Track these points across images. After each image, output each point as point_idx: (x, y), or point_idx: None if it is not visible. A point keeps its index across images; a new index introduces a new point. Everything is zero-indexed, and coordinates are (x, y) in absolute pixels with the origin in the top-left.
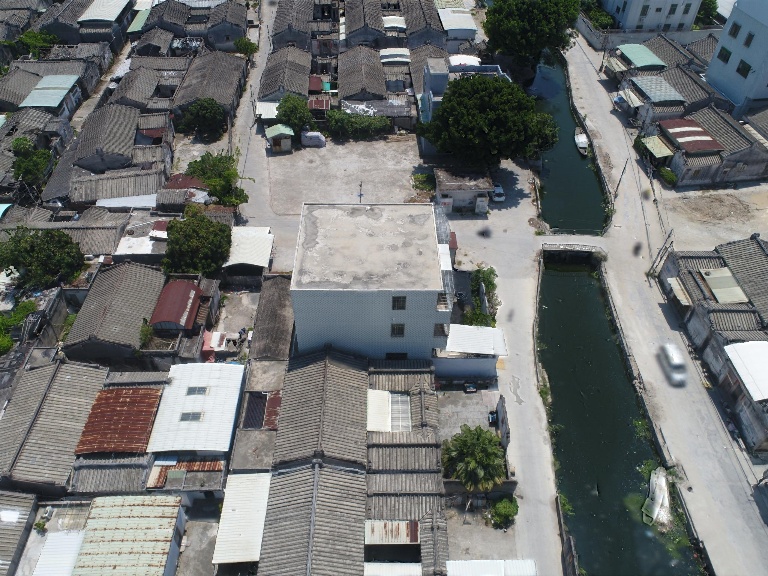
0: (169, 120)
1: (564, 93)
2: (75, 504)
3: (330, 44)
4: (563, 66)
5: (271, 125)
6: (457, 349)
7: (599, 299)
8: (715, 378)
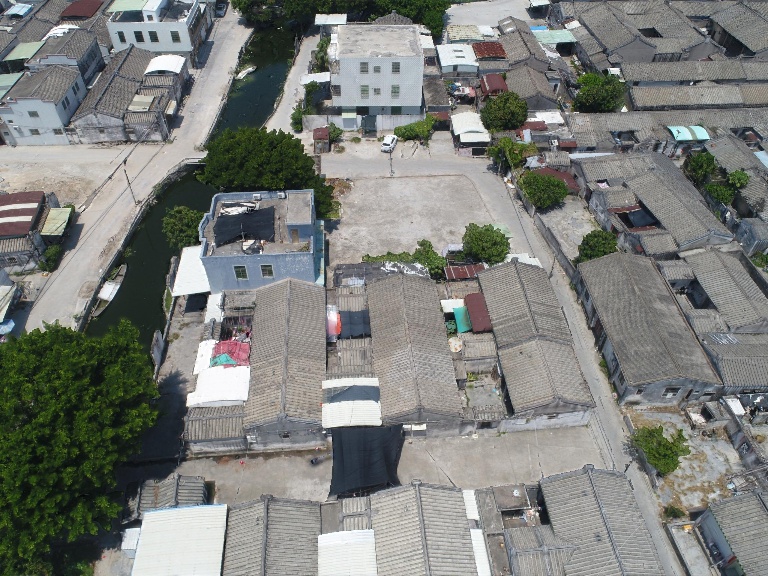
0: None
1: None
2: None
3: None
4: None
5: None
6: None
7: None
8: None
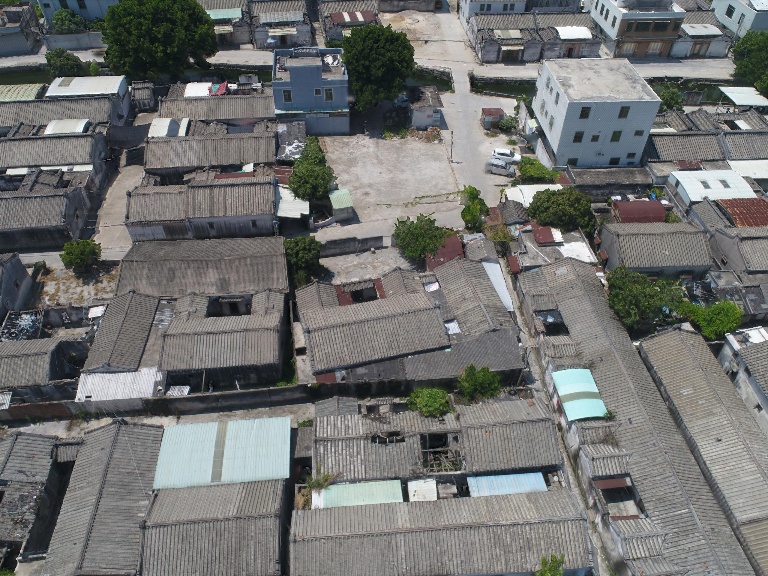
0: None
1: (223, 72)
2: None
3: (88, 184)
4: None
5: None
6: None
7: (502, 85)
8: None
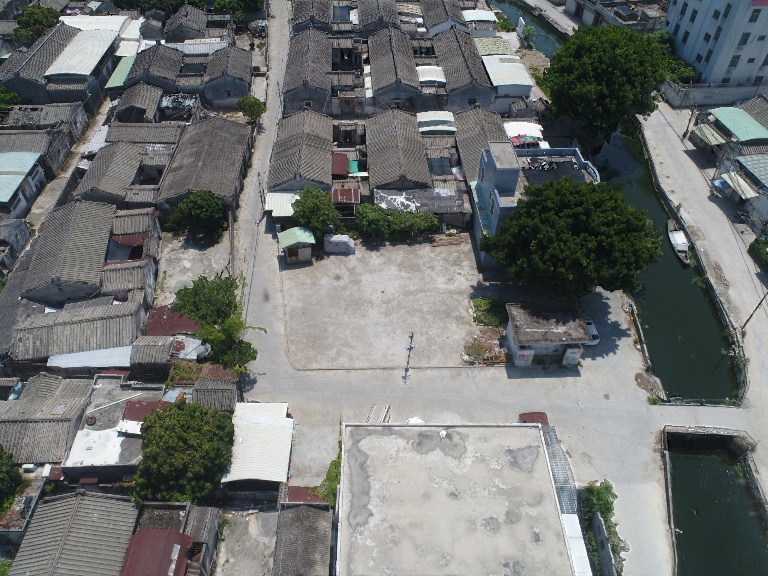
0: (153, 220)
1: (643, 167)
2: None
3: (354, 102)
4: (635, 128)
5: (284, 223)
6: None
7: (752, 515)
8: None
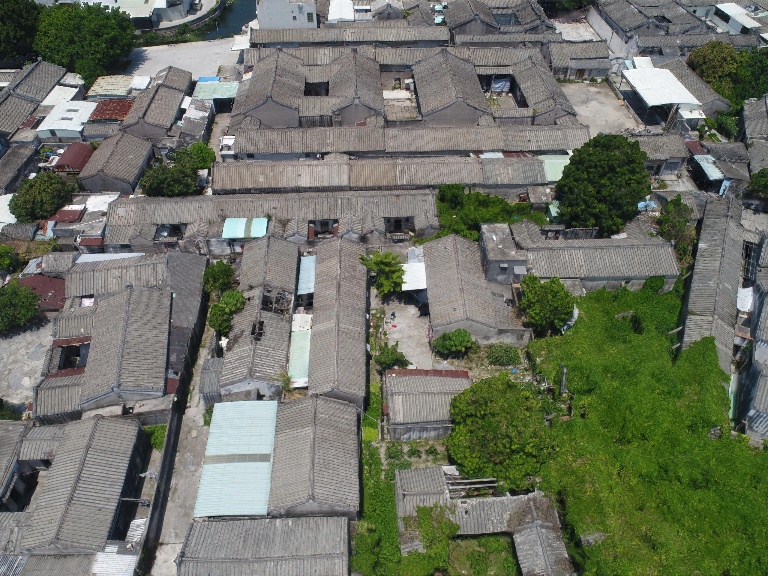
0: None
1: None
2: None
3: None
4: None
5: None
6: None
7: None
8: None
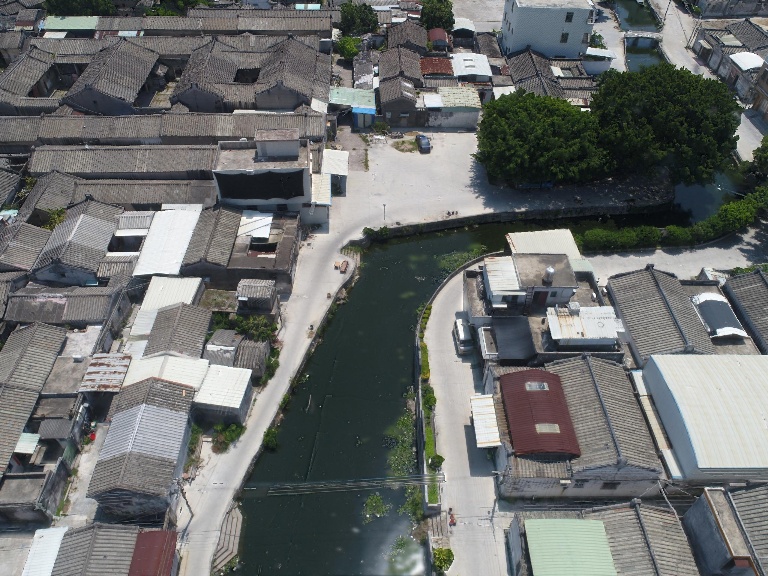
0: None
1: None
2: (429, 90)
3: None
4: None
5: None
6: (592, 54)
7: (659, 58)
8: (724, 79)
